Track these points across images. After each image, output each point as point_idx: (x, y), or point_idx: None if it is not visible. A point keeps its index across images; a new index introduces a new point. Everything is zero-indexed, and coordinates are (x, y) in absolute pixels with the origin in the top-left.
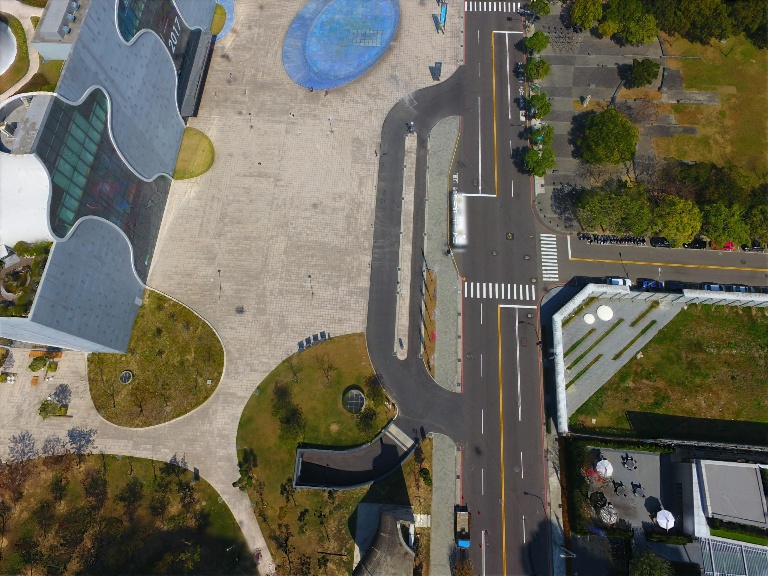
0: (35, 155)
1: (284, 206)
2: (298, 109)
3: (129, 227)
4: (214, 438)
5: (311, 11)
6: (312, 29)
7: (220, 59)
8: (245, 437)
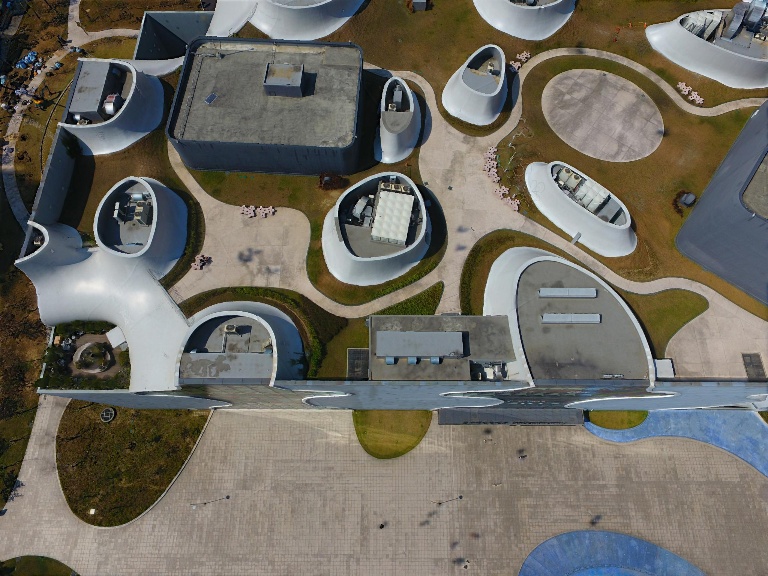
0: (178, 386)
1: (318, 574)
2: (478, 573)
3: (246, 403)
4: (32, 528)
5: (670, 569)
6: (634, 575)
7: (549, 435)
8: (27, 567)
